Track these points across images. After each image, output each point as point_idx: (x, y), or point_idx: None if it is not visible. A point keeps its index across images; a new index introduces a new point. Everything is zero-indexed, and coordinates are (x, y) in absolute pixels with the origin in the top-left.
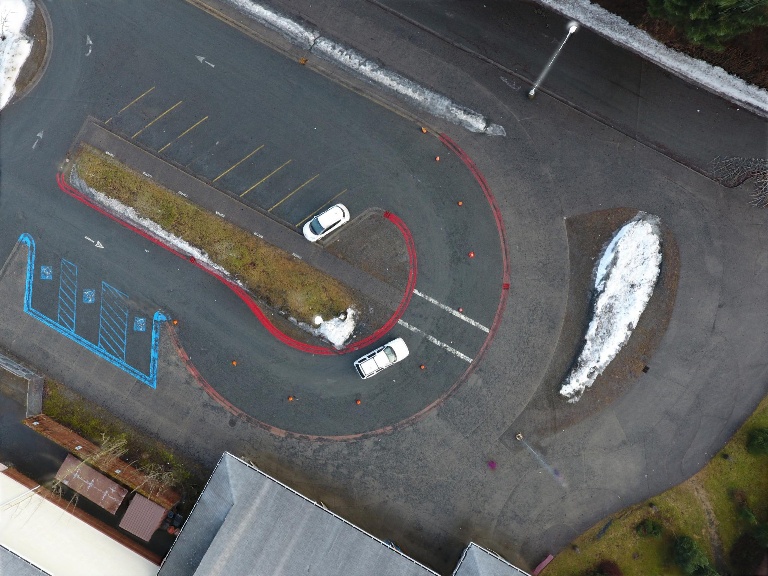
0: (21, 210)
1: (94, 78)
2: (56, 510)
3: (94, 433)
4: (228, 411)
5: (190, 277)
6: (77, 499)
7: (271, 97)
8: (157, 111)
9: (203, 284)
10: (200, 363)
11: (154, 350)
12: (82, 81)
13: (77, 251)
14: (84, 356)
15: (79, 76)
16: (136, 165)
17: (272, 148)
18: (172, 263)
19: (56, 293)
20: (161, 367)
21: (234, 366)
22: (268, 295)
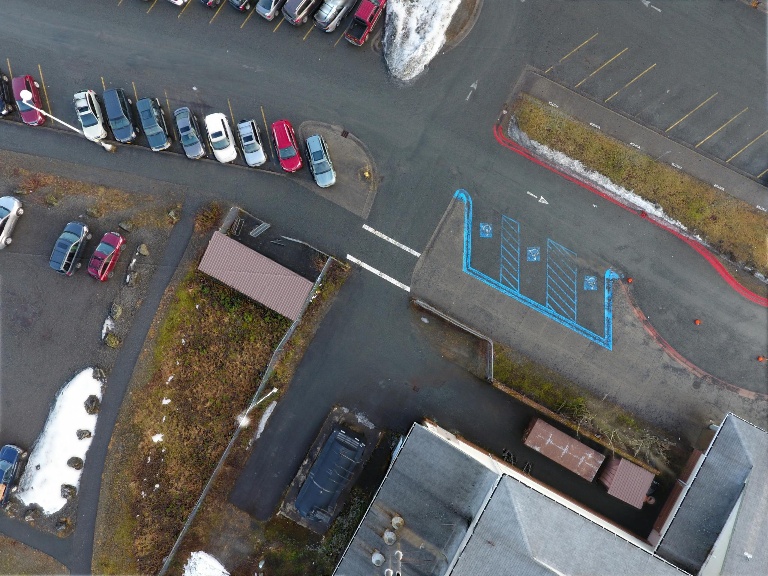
0: (456, 165)
1: (531, 25)
2: (524, 478)
3: (547, 398)
4: (691, 373)
5: (643, 233)
6: (530, 467)
7: (723, 42)
8: (602, 58)
9: (657, 240)
10: (659, 323)
11: (607, 310)
12: (518, 28)
13: (519, 207)
14: (531, 317)
15: (515, 23)
16: (582, 115)
17: (727, 96)
18: (623, 218)
19: (497, 252)
20: (617, 327)
21: (696, 325)
22: (731, 250)
